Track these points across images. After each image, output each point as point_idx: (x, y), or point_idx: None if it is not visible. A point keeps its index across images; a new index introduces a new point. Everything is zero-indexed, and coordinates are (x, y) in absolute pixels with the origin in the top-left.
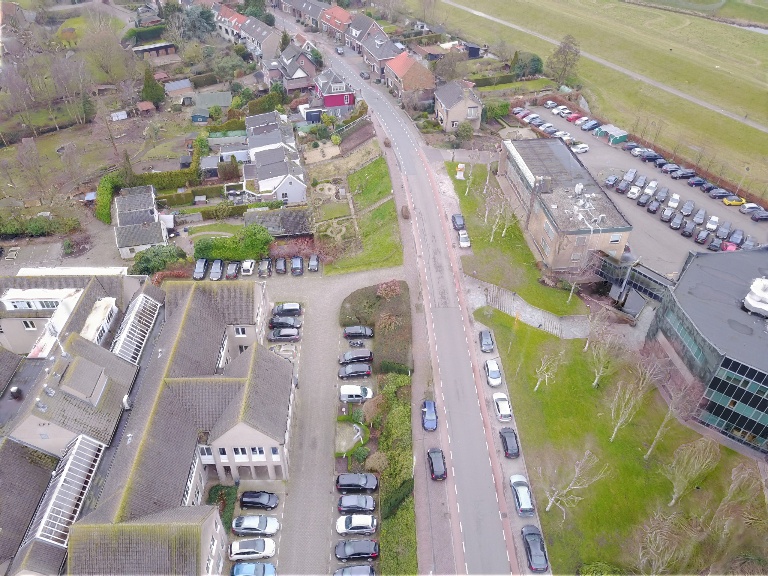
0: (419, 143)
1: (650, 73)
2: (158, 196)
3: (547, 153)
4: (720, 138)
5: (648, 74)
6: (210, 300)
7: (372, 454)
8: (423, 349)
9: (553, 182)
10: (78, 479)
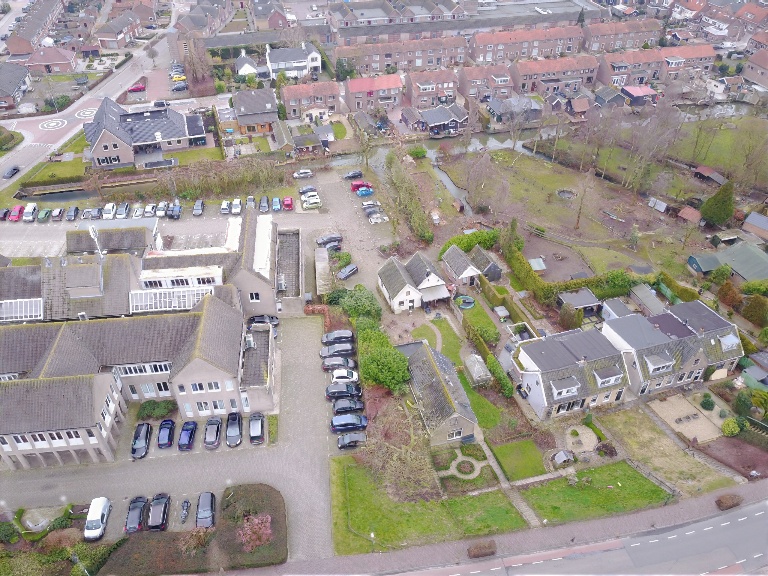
0: None
1: None
2: (482, 275)
3: None
4: None
5: None
6: (191, 333)
7: (4, 545)
8: None
9: None
10: (7, 311)
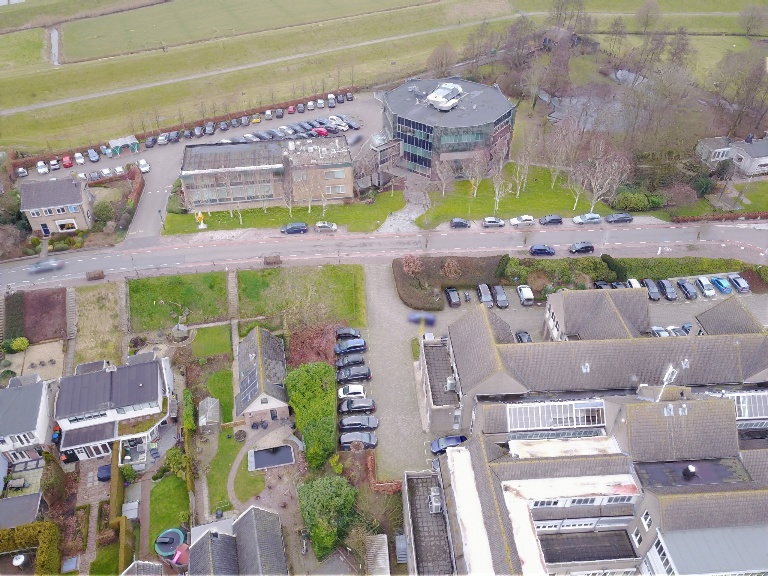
0: (105, 252)
1: (5, 105)
2: (122, 570)
3: (215, 156)
4: (152, 105)
5: (6, 106)
6: None
7: None
8: (474, 254)
9: (272, 158)
10: None
